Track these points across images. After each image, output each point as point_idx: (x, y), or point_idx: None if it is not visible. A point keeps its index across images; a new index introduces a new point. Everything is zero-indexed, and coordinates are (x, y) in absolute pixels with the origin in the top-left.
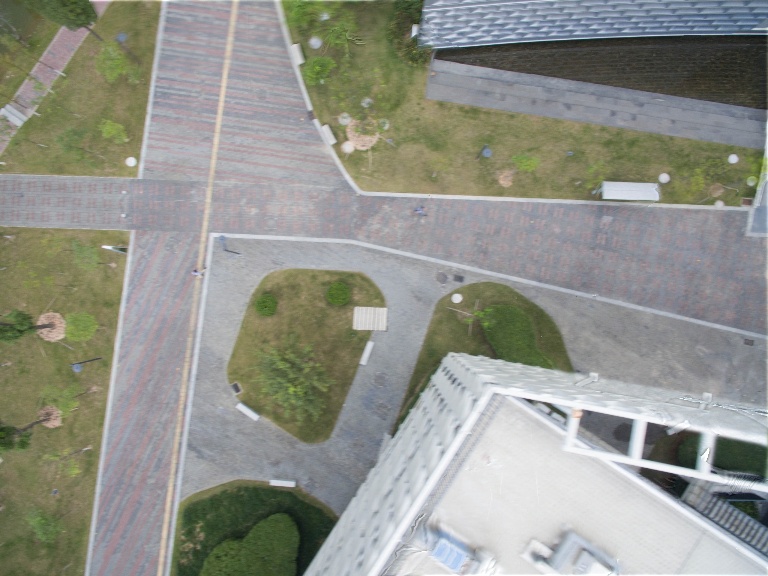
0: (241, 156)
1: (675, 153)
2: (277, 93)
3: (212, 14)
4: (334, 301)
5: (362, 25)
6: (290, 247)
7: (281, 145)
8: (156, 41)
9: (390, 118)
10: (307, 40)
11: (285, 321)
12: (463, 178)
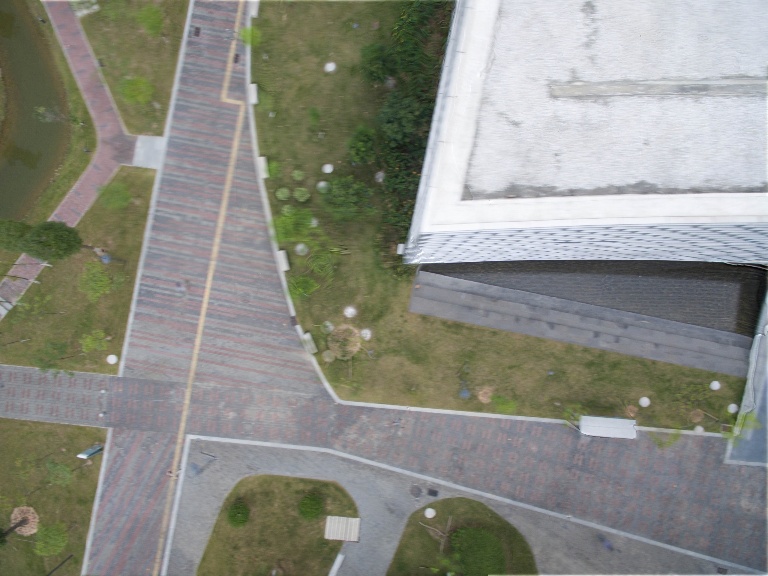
0: (222, 359)
1: (656, 377)
2: (261, 297)
3: (200, 214)
4: (307, 510)
5: (349, 234)
6: (266, 453)
7: (262, 350)
8: (143, 239)
9: (372, 329)
10: (293, 247)
11: (257, 528)
12: (442, 392)
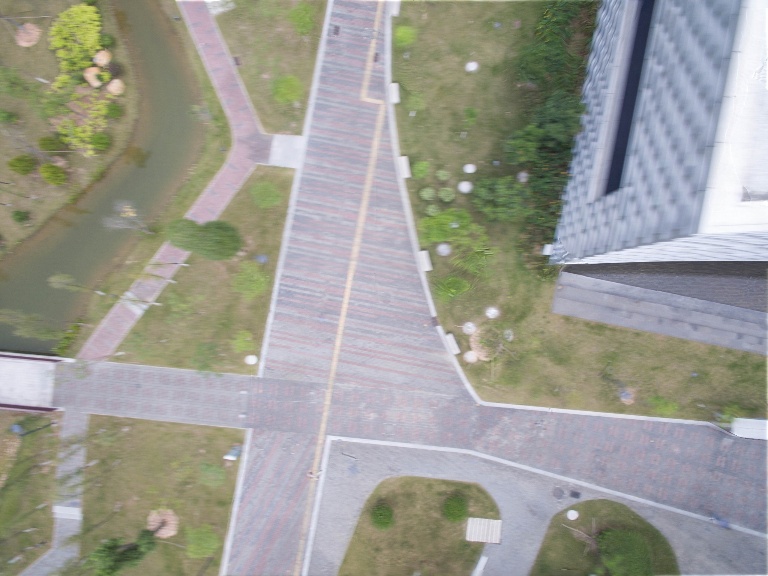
0: (362, 359)
1: None
2: (401, 297)
3: (340, 214)
4: (449, 512)
5: (491, 235)
6: (407, 454)
7: (403, 350)
8: (282, 238)
9: (515, 330)
10: (435, 247)
11: (399, 530)
12: (585, 393)
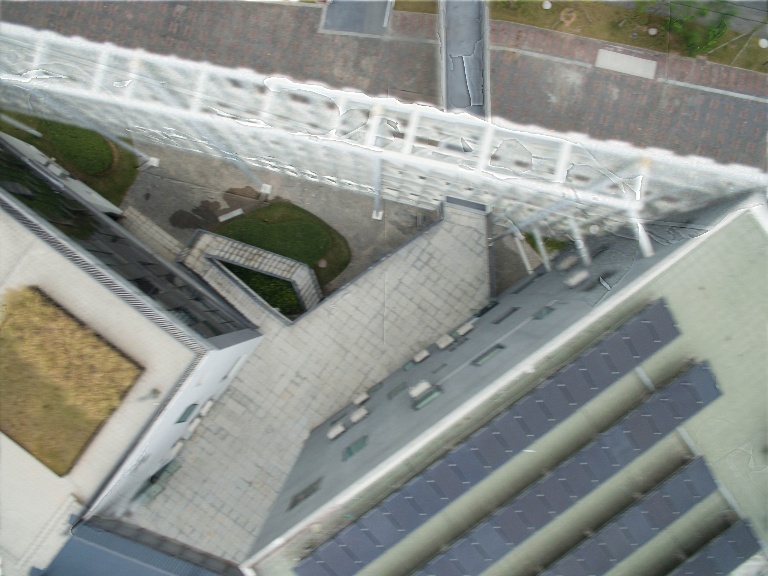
0: None
1: None
2: None
3: None
4: None
5: None
6: None
7: None
8: None
9: None
10: None
11: None
12: None
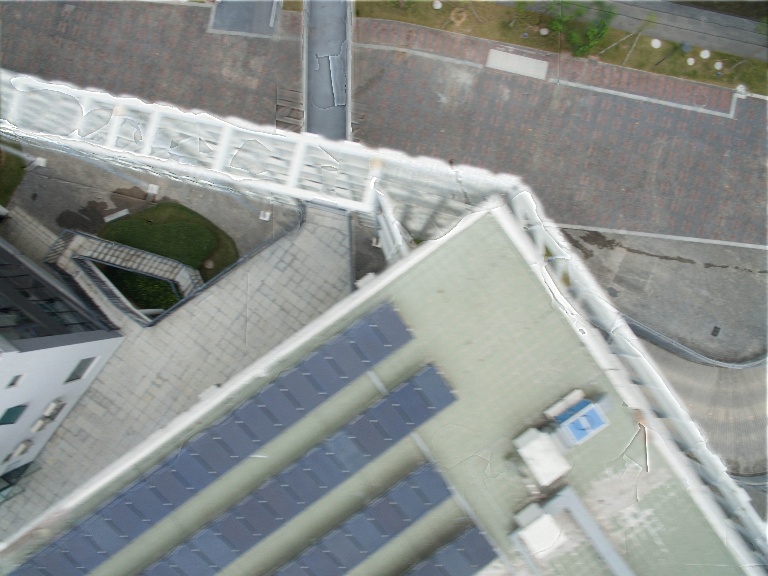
0: None
1: None
2: None
3: None
4: None
5: None
6: None
7: None
8: None
9: None
10: None
11: None
12: None
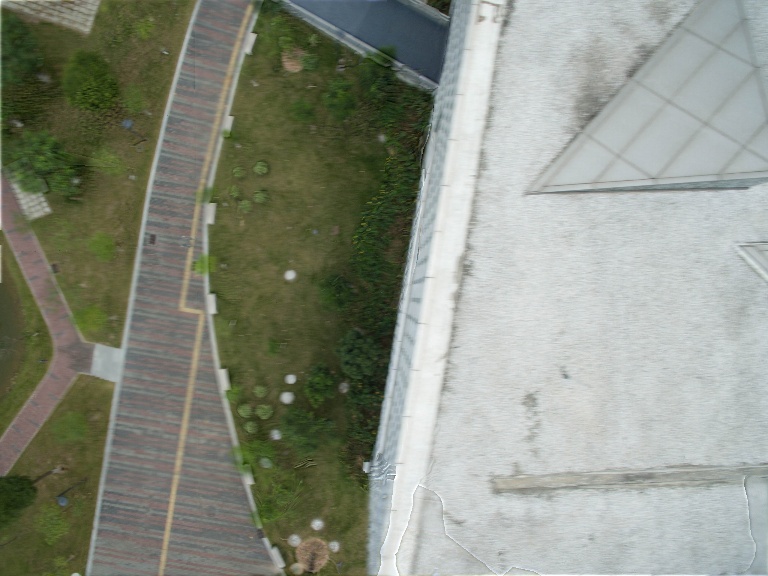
0: (188, 574)
1: None
2: (226, 510)
3: (162, 427)
4: None
5: (314, 446)
6: None
7: (229, 563)
8: (104, 454)
9: (340, 541)
10: (257, 460)
11: None
12: None
